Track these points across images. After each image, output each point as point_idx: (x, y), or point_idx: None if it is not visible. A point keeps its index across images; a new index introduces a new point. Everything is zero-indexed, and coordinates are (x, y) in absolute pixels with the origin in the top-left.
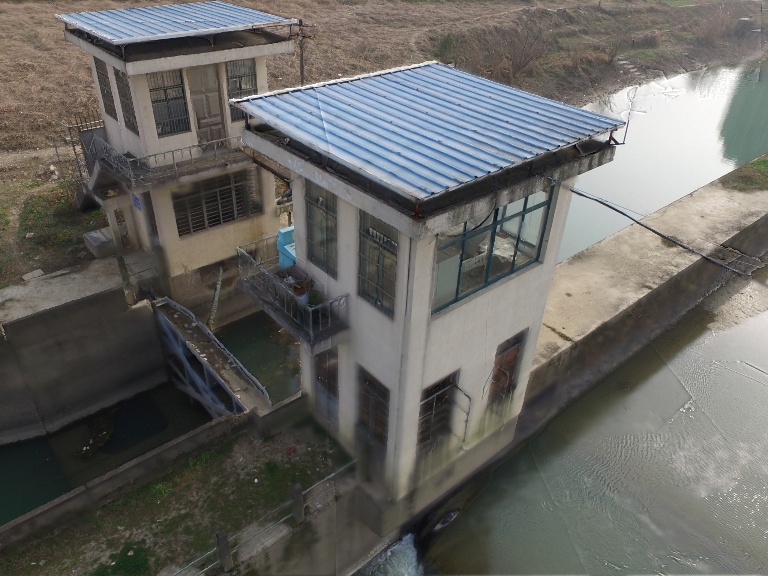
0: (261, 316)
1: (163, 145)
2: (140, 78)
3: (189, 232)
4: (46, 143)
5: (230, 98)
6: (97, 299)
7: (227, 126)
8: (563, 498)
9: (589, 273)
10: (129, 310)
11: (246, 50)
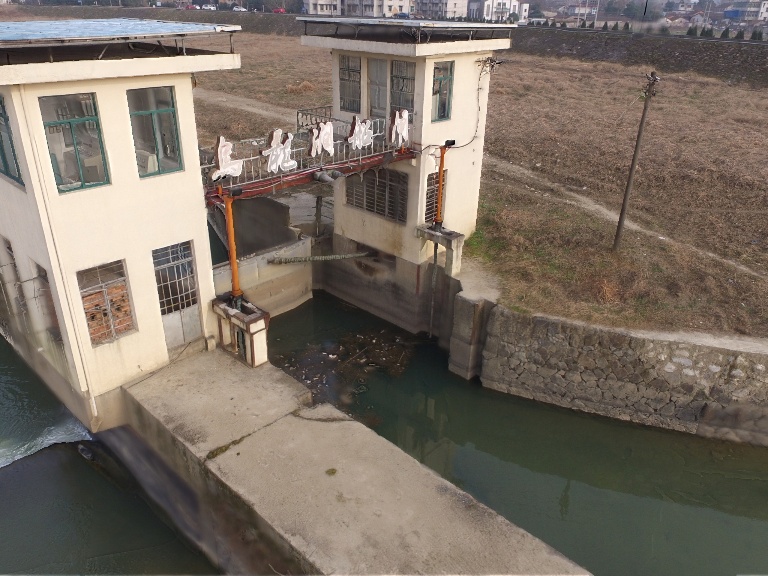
0: (382, 324)
1: (342, 117)
2: (336, 57)
3: (353, 204)
4: (522, 162)
5: (393, 96)
6: (275, 205)
7: (386, 121)
8: (87, 570)
9: (411, 510)
10: (287, 227)
11: (375, 44)
